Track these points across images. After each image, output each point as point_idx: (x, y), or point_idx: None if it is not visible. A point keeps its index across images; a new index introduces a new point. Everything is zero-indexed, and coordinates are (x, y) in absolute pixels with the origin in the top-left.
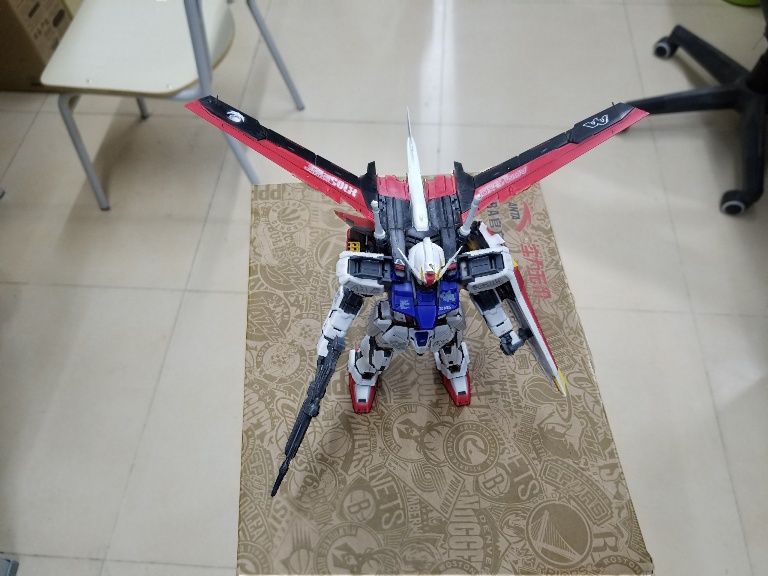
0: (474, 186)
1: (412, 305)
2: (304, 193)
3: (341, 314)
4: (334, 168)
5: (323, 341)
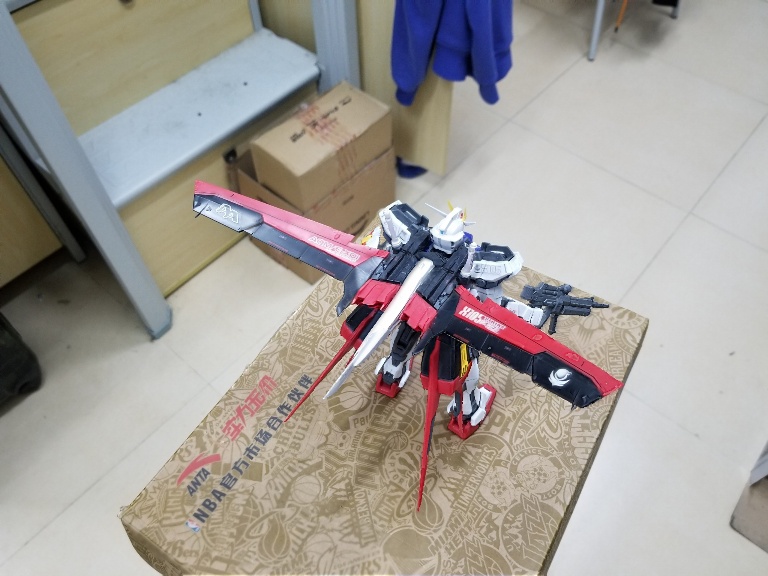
0: (354, 269)
1: None
2: None
3: None
4: (468, 336)
5: (536, 310)
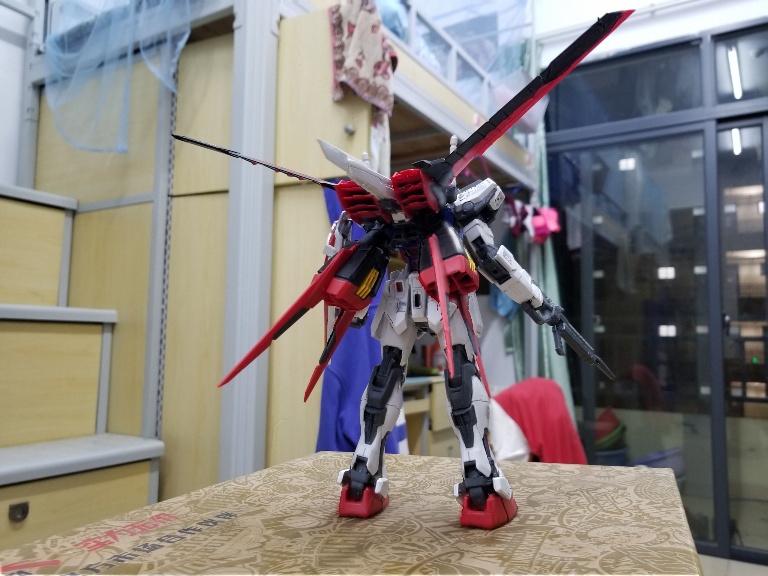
0: None
1: None
2: None
3: None
4: None
5: None
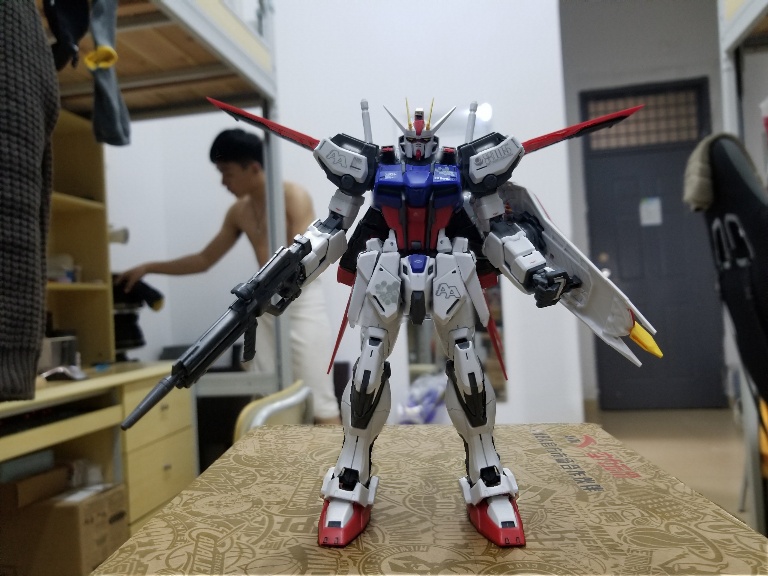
0: None
1: (400, 175)
2: (313, 429)
3: (313, 232)
4: None
5: None
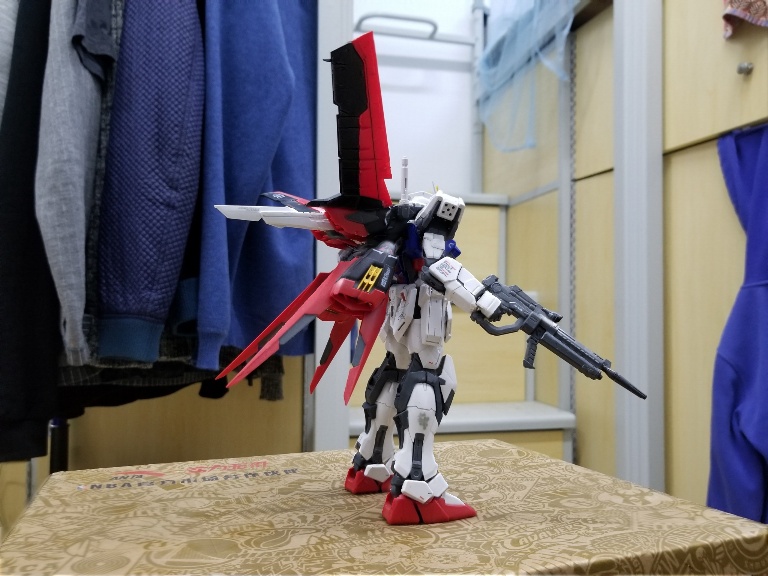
0: None
1: None
2: None
3: None
4: None
5: None
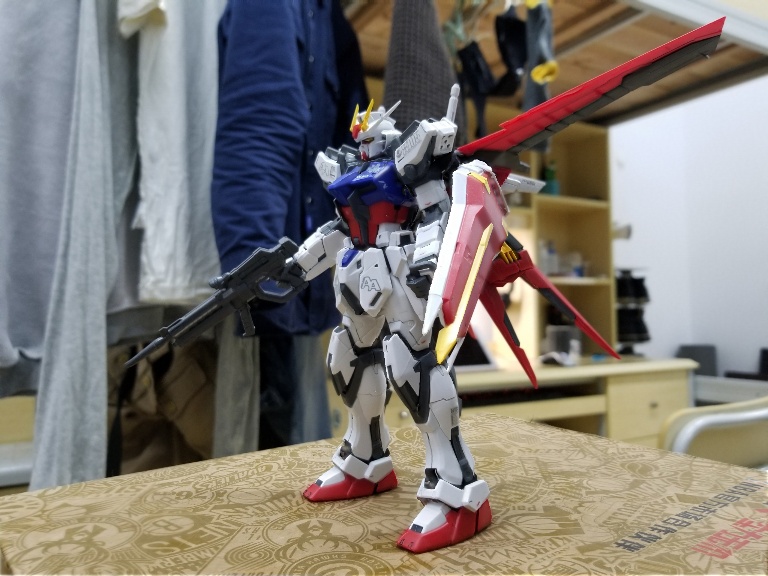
0: None
1: None
2: (519, 424)
3: None
4: None
5: None
